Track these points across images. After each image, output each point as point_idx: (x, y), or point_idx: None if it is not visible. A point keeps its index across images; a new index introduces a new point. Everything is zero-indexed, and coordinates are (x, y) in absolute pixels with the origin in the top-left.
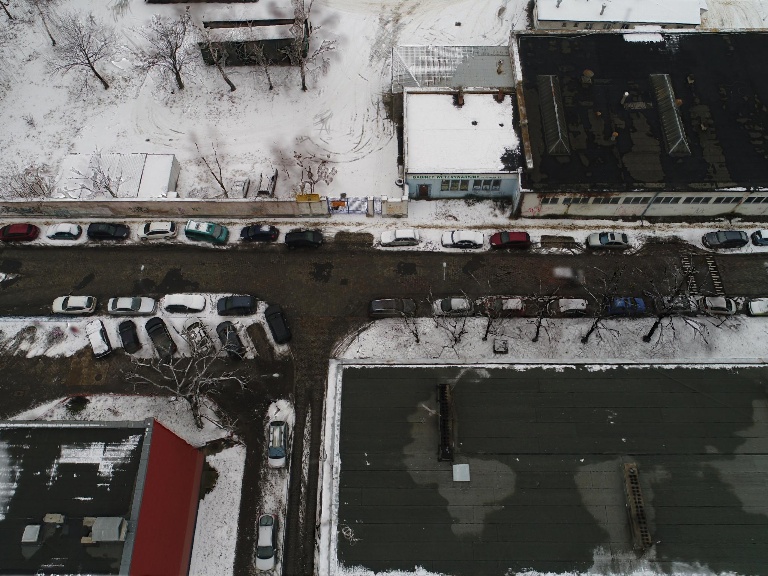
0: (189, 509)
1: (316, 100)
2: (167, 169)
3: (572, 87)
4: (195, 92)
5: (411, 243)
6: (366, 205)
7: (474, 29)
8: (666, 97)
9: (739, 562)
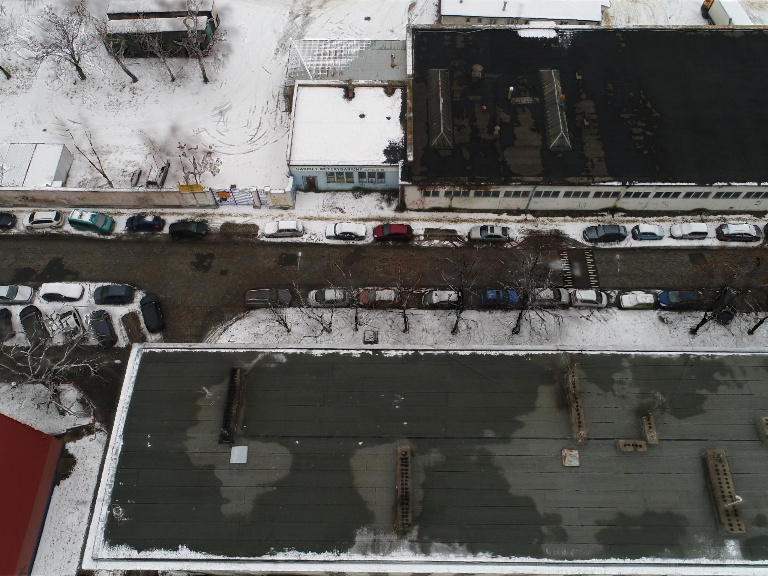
0: (36, 494)
1: (217, 92)
2: (55, 159)
3: (462, 81)
4: (97, 83)
5: (294, 234)
6: (251, 196)
7: (383, 24)
8: (551, 92)
9: (497, 543)
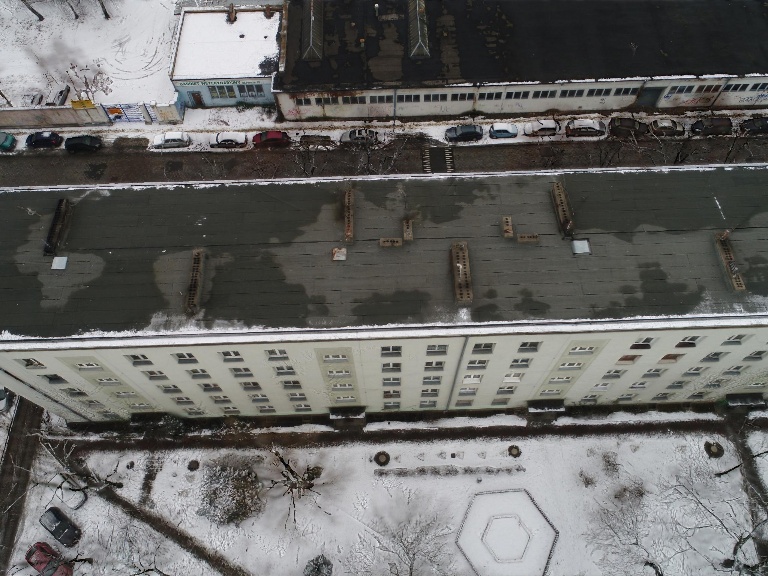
0: None
1: (117, 27)
2: None
3: (334, 3)
4: (6, 23)
5: (180, 144)
6: (141, 112)
7: None
8: (414, 8)
9: (269, 318)
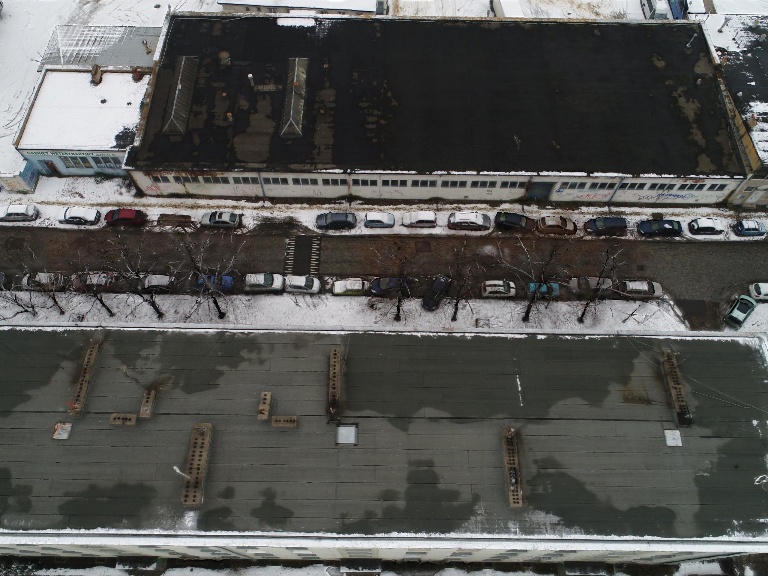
0: None
1: None
2: None
3: (209, 68)
4: None
5: (25, 219)
6: None
7: None
8: (292, 80)
9: None
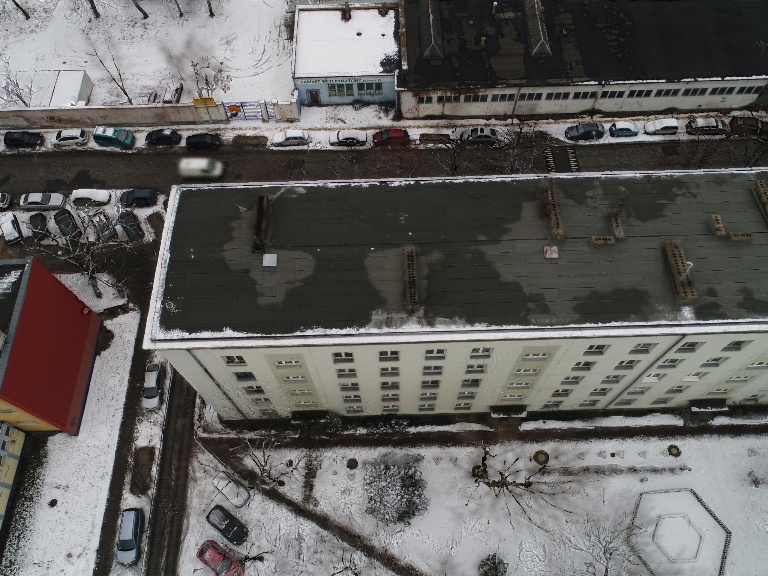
0: (82, 357)
1: (223, 25)
2: (78, 83)
3: (449, 1)
4: (110, 20)
5: (301, 142)
6: (260, 110)
7: None
8: (532, 6)
9: (491, 316)
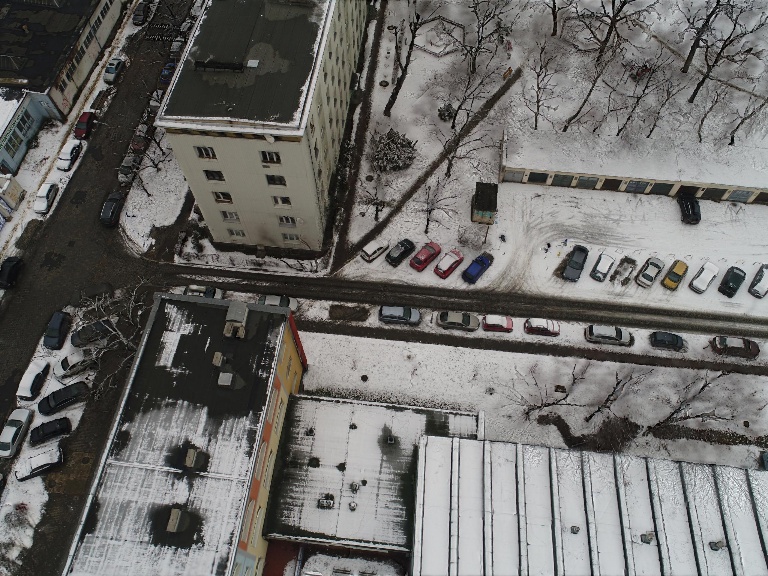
0: None
1: None
2: None
3: None
4: None
5: (55, 190)
6: None
7: None
8: None
9: None
